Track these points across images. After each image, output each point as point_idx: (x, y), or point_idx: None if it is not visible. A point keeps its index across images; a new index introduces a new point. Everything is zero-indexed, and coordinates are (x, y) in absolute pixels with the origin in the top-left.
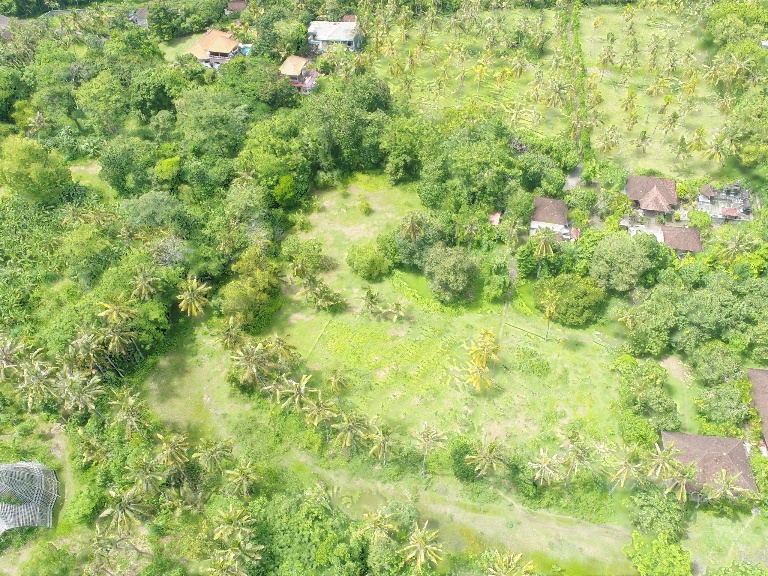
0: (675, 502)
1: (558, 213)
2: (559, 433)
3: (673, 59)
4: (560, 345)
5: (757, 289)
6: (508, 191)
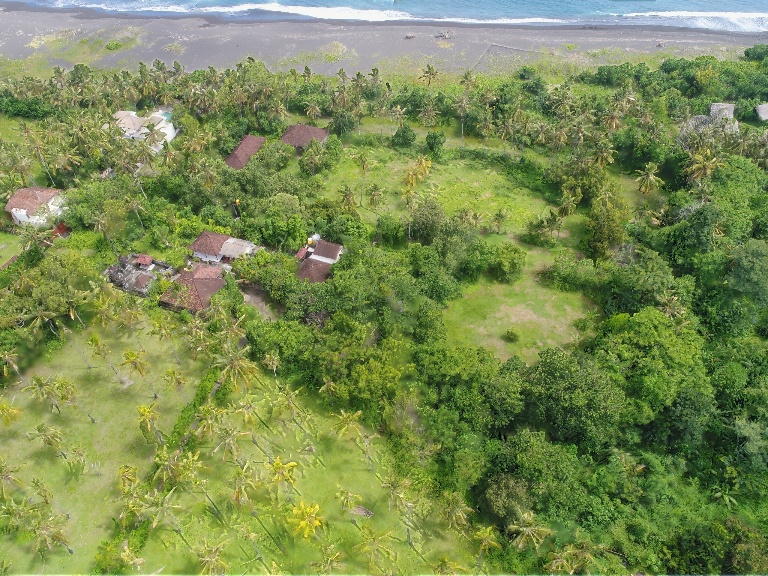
0: (335, 118)
1: None
2: (376, 162)
3: None
4: None
5: None
6: None
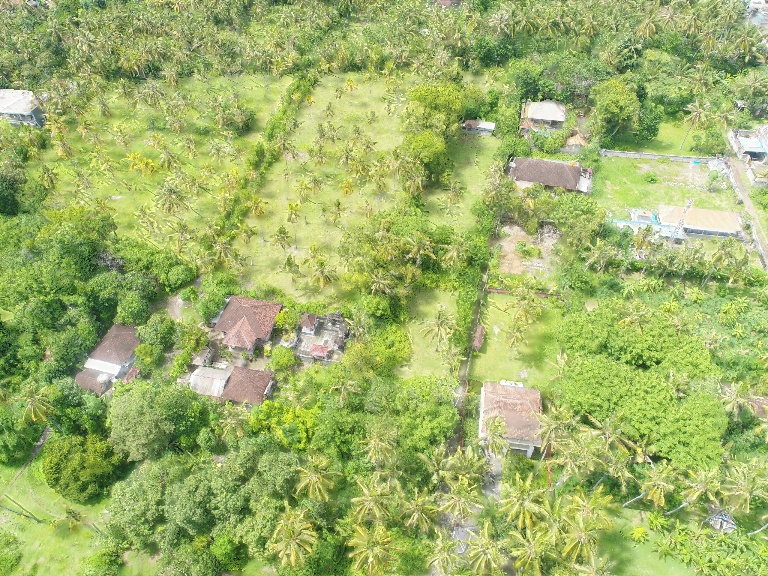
0: None
1: (117, 350)
2: None
3: (346, 151)
4: (50, 529)
5: (267, 470)
6: (68, 321)
